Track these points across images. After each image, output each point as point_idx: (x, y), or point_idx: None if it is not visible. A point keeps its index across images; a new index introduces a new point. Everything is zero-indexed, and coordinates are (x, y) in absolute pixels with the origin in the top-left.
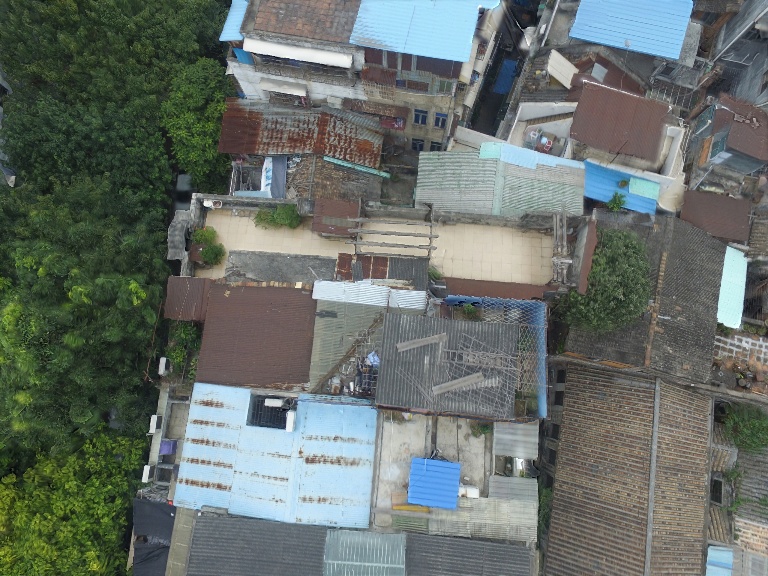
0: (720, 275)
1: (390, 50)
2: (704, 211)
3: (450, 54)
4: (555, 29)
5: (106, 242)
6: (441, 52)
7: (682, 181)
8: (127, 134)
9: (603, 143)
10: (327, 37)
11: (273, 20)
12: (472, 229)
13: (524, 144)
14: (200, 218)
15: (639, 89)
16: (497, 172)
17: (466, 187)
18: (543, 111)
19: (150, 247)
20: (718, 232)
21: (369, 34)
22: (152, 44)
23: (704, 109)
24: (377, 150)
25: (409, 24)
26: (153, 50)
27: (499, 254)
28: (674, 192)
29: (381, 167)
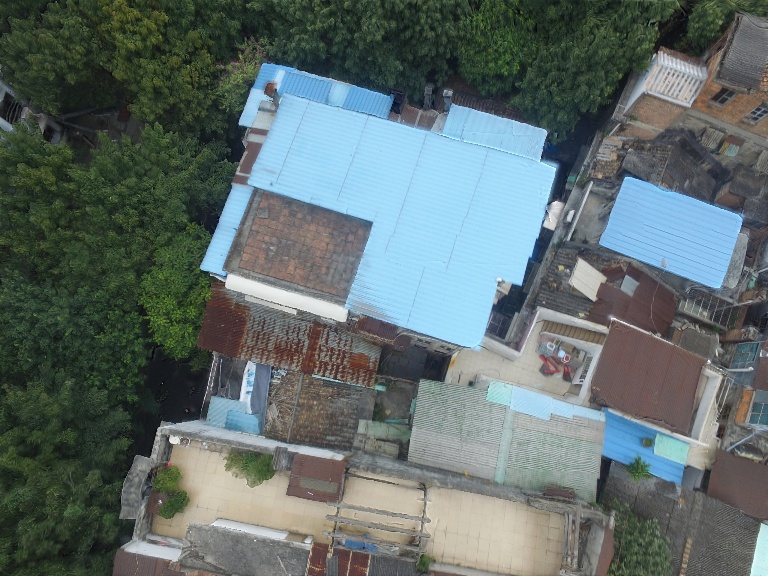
0: (751, 560)
1: (391, 322)
2: (738, 485)
3: (460, 339)
4: (584, 214)
5: (49, 502)
6: (450, 332)
7: (715, 433)
8: (99, 316)
9: (629, 404)
10: (321, 287)
11: (261, 258)
12: (471, 495)
13: (539, 349)
14: (165, 450)
15: (672, 299)
16: (505, 423)
17: (468, 435)
18: (563, 320)
19: (110, 461)
20: (753, 512)
21: (368, 298)
22: (136, 213)
23: (745, 341)
24: (373, 365)
25: (416, 290)
26: (137, 220)
27: (499, 530)
28: (705, 446)
29: (376, 380)
